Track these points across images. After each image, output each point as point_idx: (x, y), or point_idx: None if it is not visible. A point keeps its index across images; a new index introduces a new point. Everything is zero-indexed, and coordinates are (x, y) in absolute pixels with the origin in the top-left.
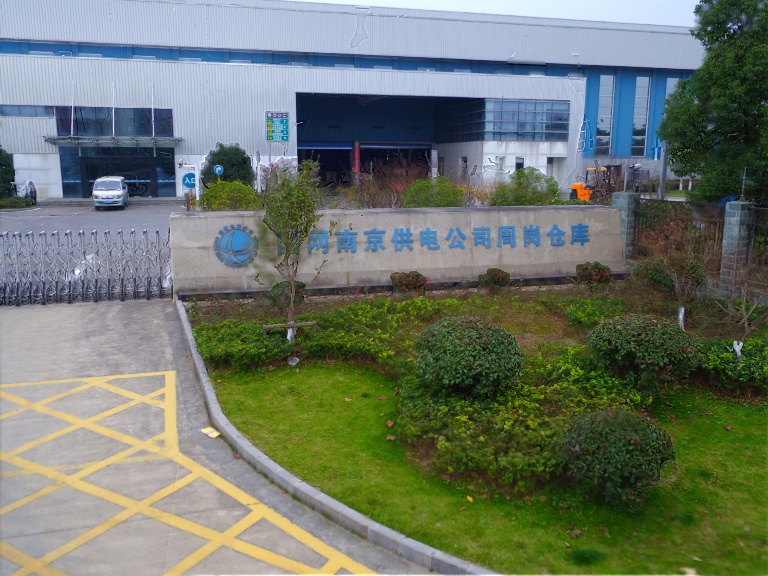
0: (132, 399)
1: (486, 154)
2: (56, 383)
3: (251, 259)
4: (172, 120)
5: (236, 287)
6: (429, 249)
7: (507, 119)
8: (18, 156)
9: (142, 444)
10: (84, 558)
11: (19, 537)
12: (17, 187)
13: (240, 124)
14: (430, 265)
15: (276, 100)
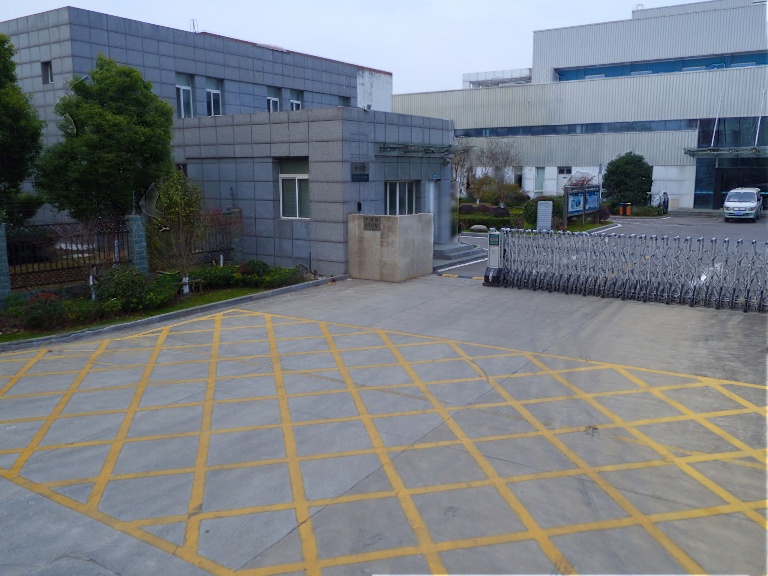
0: (746, 407)
1: None
2: (673, 375)
3: None
4: None
5: None
6: None
7: None
8: (657, 168)
9: (752, 451)
10: (685, 531)
11: (631, 492)
12: (652, 197)
13: None
14: None
15: None
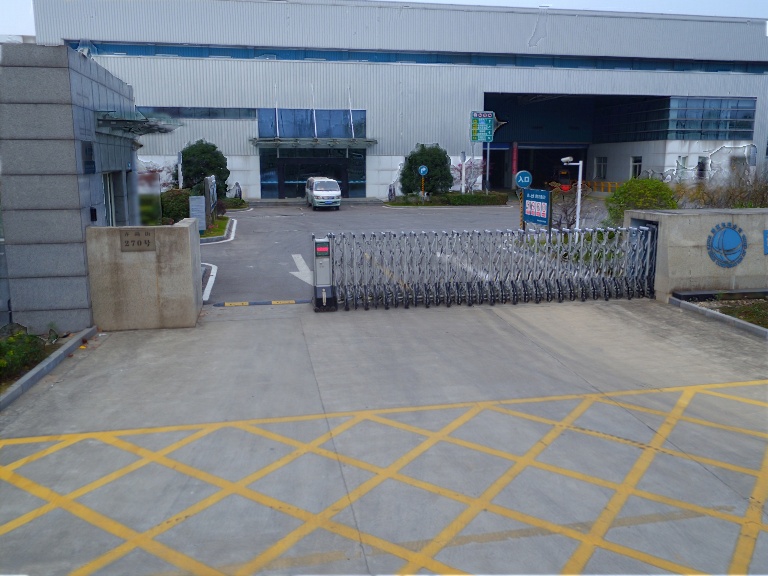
0: None
1: (669, 153)
2: (751, 385)
3: (740, 259)
4: (365, 121)
5: (725, 287)
6: None
7: (691, 117)
8: None
9: None
10: None
11: None
12: None
13: (429, 125)
14: None
15: (465, 100)
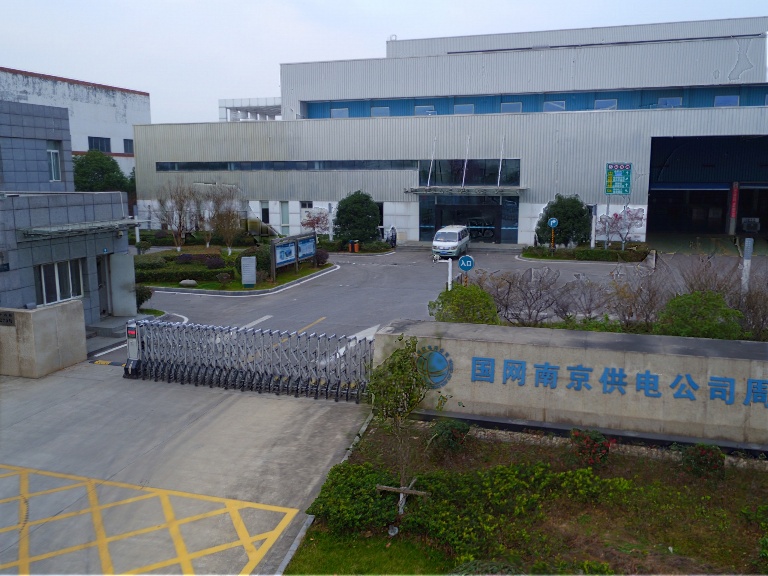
0: (239, 538)
1: None
2: (207, 500)
3: (444, 382)
4: (519, 170)
5: (428, 407)
6: (646, 395)
7: None
8: (387, 204)
9: None
10: None
11: None
12: (384, 230)
13: (587, 172)
14: (646, 414)
15: (628, 146)
